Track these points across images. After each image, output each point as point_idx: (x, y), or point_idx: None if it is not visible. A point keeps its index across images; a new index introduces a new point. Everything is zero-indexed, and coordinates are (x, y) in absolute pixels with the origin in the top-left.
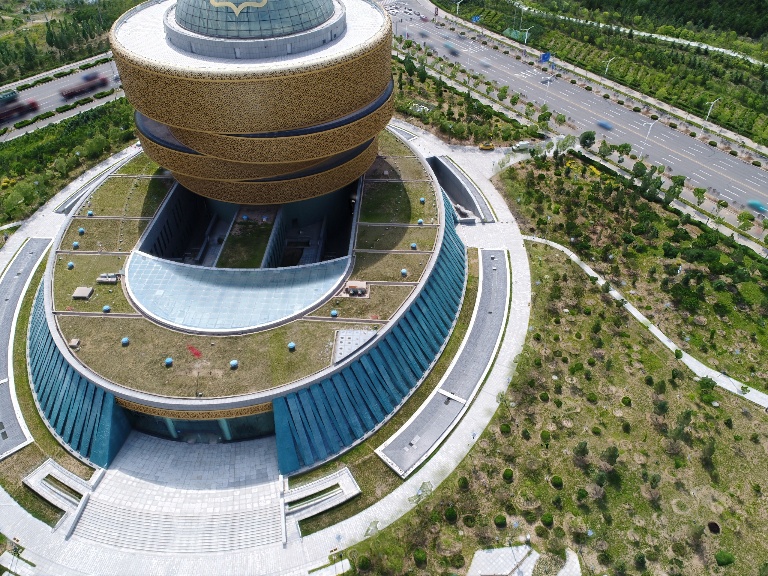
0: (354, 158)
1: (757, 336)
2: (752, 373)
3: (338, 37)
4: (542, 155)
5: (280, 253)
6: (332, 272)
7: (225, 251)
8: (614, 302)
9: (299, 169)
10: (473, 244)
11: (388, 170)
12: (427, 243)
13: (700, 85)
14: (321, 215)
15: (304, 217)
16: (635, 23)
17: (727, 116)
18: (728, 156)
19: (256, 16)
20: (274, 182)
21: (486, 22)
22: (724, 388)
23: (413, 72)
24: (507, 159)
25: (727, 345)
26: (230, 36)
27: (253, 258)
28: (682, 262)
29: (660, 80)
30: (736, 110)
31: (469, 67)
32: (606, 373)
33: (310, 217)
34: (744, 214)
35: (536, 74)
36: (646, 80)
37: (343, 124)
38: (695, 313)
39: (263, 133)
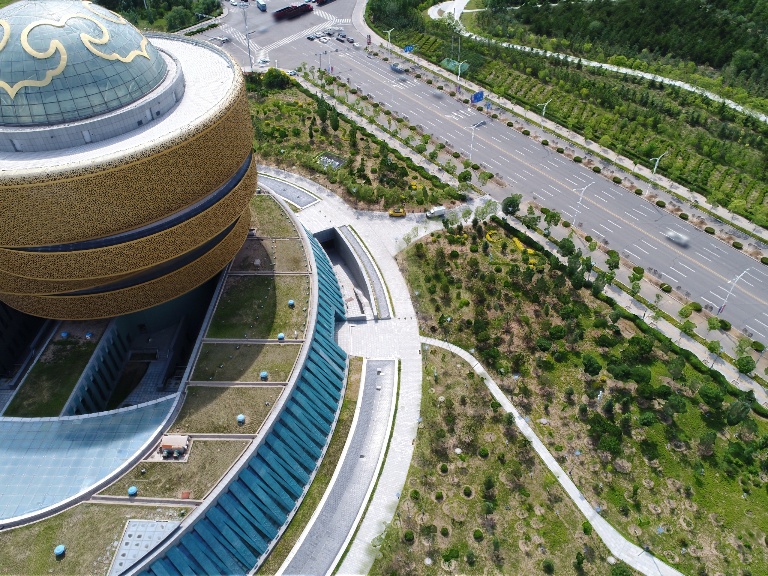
0: (202, 256)
1: (693, 489)
2: (683, 549)
3: (164, 114)
4: (459, 224)
5: (114, 374)
6: (148, 421)
7: (24, 388)
8: (519, 437)
9: (126, 276)
10: (358, 351)
11: (261, 258)
12: (283, 369)
13: (651, 128)
14: (177, 316)
15: (153, 321)
16: (585, 51)
17: (677, 171)
18: (677, 220)
19: (39, 97)
20: (91, 295)
21: (424, 50)
22: (645, 575)
23: (326, 118)
24: (414, 233)
25: (654, 503)
26: (7, 123)
27: (56, 399)
28: (608, 377)
29: (606, 122)
30: (690, 160)
31: (395, 107)
32: (495, 552)
33: (162, 321)
34: (686, 309)
35: (469, 115)
36: (591, 122)
37: (165, 228)
38: (617, 454)
39: (56, 245)
